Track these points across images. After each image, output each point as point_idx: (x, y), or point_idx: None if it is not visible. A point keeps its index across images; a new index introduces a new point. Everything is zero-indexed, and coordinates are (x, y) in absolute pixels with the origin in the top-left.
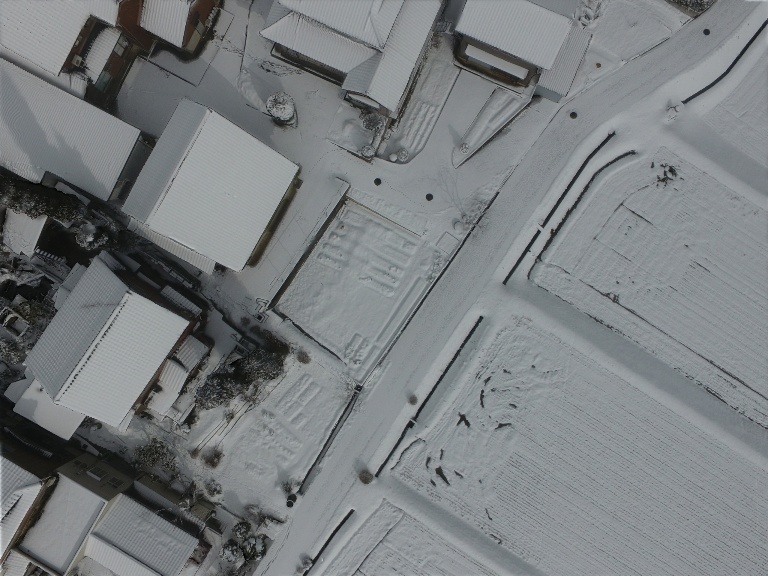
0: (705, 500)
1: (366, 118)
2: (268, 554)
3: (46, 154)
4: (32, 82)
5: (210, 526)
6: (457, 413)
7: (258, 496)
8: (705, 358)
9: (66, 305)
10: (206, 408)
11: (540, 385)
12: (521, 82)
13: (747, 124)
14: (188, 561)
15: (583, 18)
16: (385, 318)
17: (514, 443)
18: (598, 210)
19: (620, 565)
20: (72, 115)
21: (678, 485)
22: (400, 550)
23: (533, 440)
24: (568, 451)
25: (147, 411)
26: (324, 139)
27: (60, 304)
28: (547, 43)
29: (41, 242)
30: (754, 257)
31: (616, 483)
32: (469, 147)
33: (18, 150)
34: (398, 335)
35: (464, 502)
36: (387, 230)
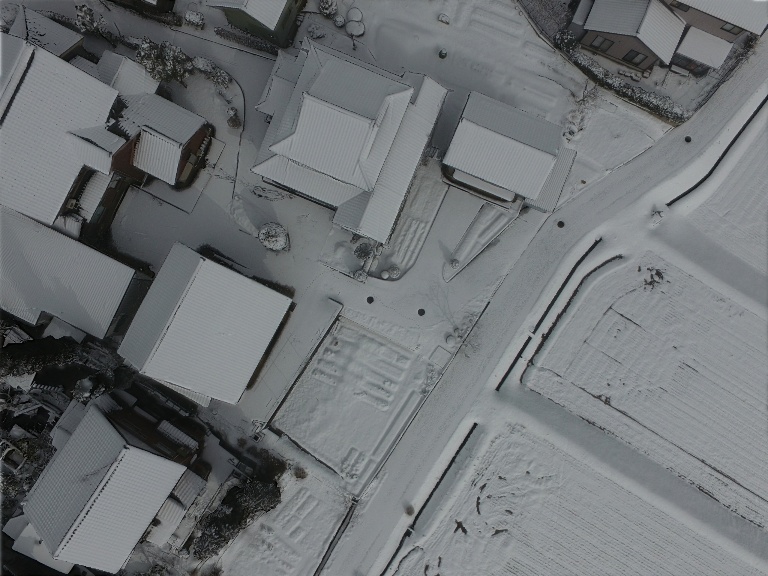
0: None
1: (357, 248)
2: None
3: (42, 299)
4: (27, 228)
5: None
6: (454, 520)
7: None
8: (696, 457)
9: (64, 454)
10: None
11: (535, 491)
12: None
13: (730, 223)
14: None
15: (567, 134)
16: (380, 432)
17: (511, 549)
18: (587, 314)
19: None
20: (67, 263)
21: None
22: None
23: (530, 546)
24: (564, 556)
25: None
26: (316, 261)
27: (58, 442)
28: (532, 177)
29: (38, 378)
30: (741, 357)
31: None
32: (459, 263)
33: (14, 296)
34: None
35: None
36: (380, 345)
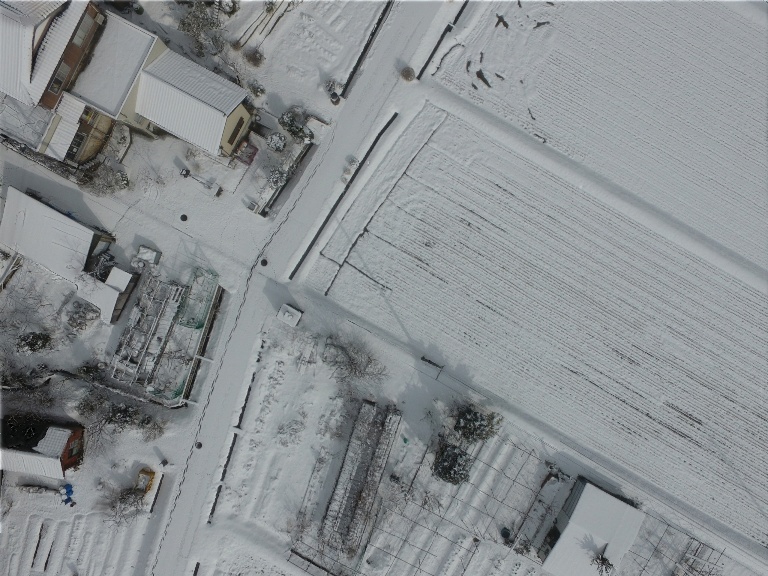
0: (747, 85)
1: None
2: (314, 158)
3: None
4: None
5: (255, 132)
6: (495, 15)
7: (301, 98)
8: None
9: None
10: None
11: None
12: None
13: None
14: (235, 163)
15: None
16: None
17: (553, 40)
18: None
19: (665, 156)
20: None
21: (719, 71)
22: (445, 149)
23: (572, 36)
24: (608, 45)
25: None
26: None
27: None
28: None
29: None
30: None
31: (657, 74)
32: None
33: None
34: None
35: (506, 103)
36: None
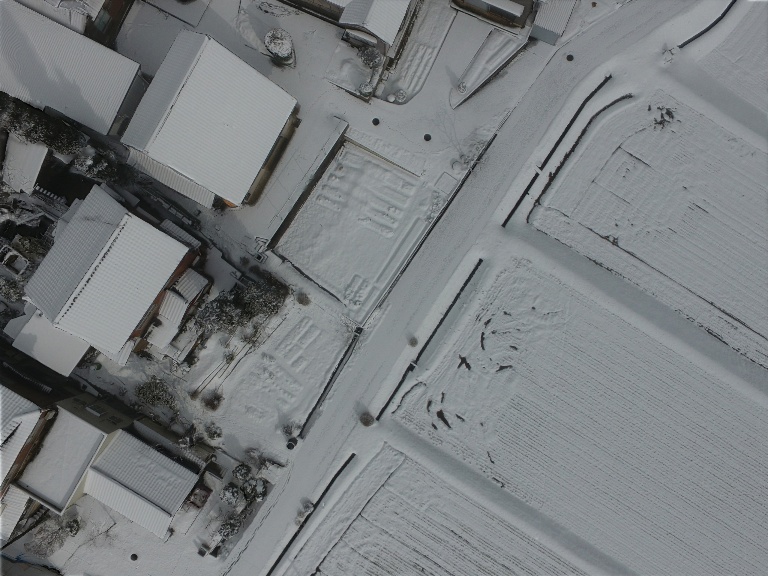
0: (708, 441)
1: (364, 53)
2: (269, 499)
3: (46, 86)
4: (32, 16)
5: (210, 471)
6: (458, 356)
7: (258, 440)
8: (705, 300)
9: (65, 232)
10: (206, 332)
11: (540, 326)
12: (517, 23)
13: (743, 69)
14: (188, 505)
15: None
16: (384, 259)
17: (515, 385)
18: (596, 153)
19: (624, 507)
20: (72, 46)
21: (681, 426)
22: (402, 494)
23: (534, 382)
24: (570, 393)
25: (147, 350)
26: (322, 79)
27: None
28: None
29: (41, 178)
30: (752, 198)
31: (618, 424)
32: (466, 87)
33: (18, 82)
34: (398, 277)
35: (466, 445)
36: (386, 171)
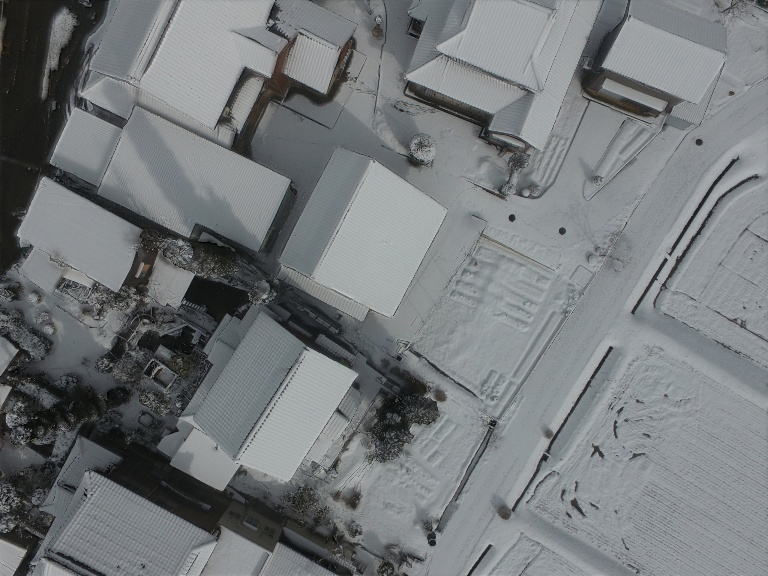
0: None
1: (511, 158)
2: None
3: (201, 208)
4: (184, 136)
5: None
6: (591, 444)
7: (397, 535)
8: None
9: (234, 361)
10: None
11: (673, 414)
12: (652, 112)
13: None
14: None
15: None
16: (521, 353)
17: (649, 473)
18: (723, 236)
19: None
20: (230, 169)
21: None
22: None
23: (668, 469)
24: (703, 479)
25: None
26: (460, 177)
27: (214, 356)
28: (698, 78)
29: (189, 294)
30: None
31: (752, 509)
32: None
33: (173, 205)
34: None
35: (600, 533)
36: (520, 265)
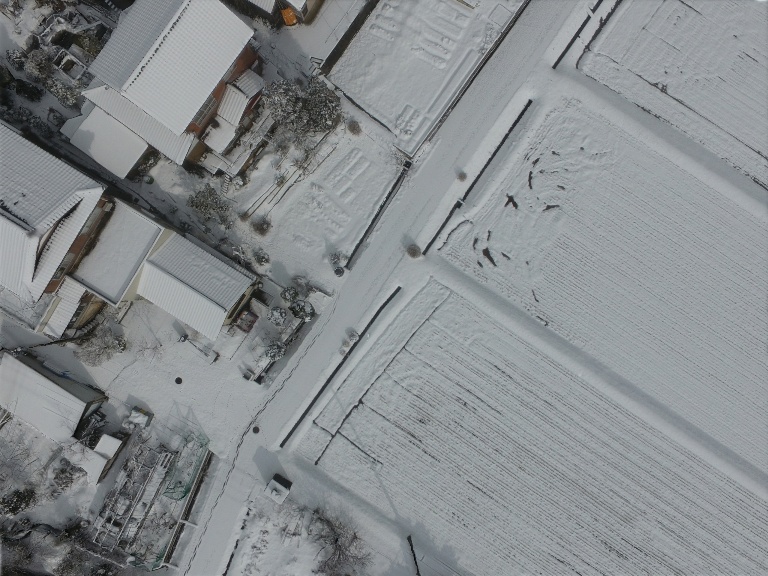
0: (753, 283)
1: None
2: (314, 328)
3: None
4: None
5: (256, 298)
6: (505, 194)
7: (305, 268)
8: (752, 149)
9: (131, 12)
10: (271, 109)
11: (589, 166)
12: None
13: None
14: (234, 330)
15: None
16: (436, 90)
17: (562, 224)
18: None
19: (667, 348)
20: None
21: (726, 268)
22: (446, 328)
23: (581, 222)
24: (616, 233)
25: (200, 163)
26: None
27: None
28: None
29: None
30: None
31: (664, 266)
32: None
33: None
34: (448, 112)
35: (511, 283)
36: (440, 1)
